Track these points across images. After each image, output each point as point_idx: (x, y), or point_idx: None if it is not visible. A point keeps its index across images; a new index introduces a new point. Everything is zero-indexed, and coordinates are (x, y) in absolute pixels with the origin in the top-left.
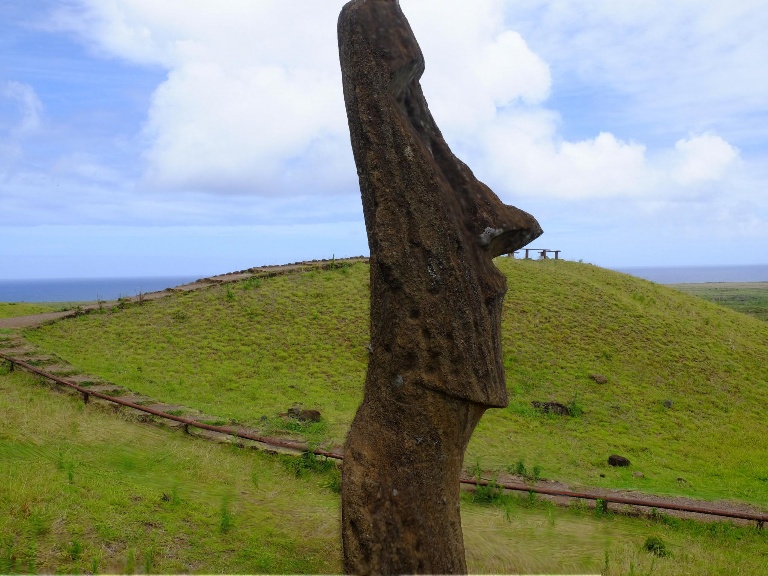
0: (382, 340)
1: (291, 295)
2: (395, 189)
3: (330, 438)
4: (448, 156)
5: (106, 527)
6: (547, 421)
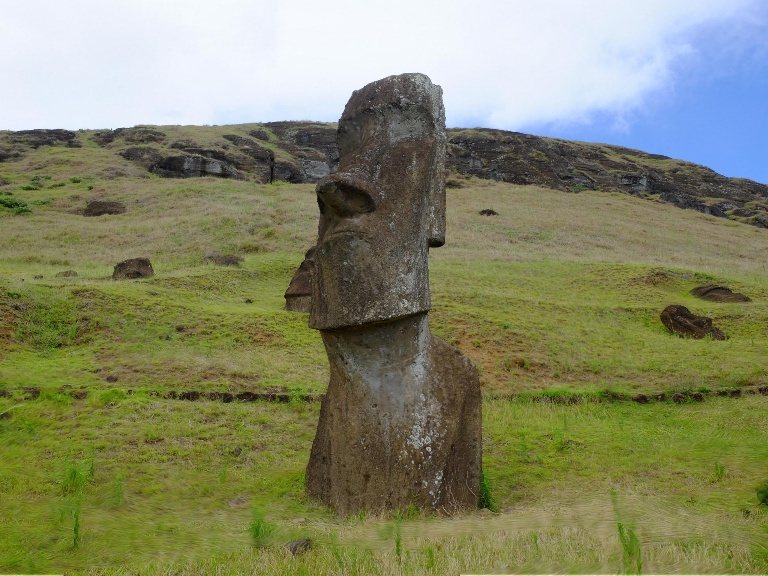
0: None
1: None
2: None
3: None
4: None
5: None
6: None
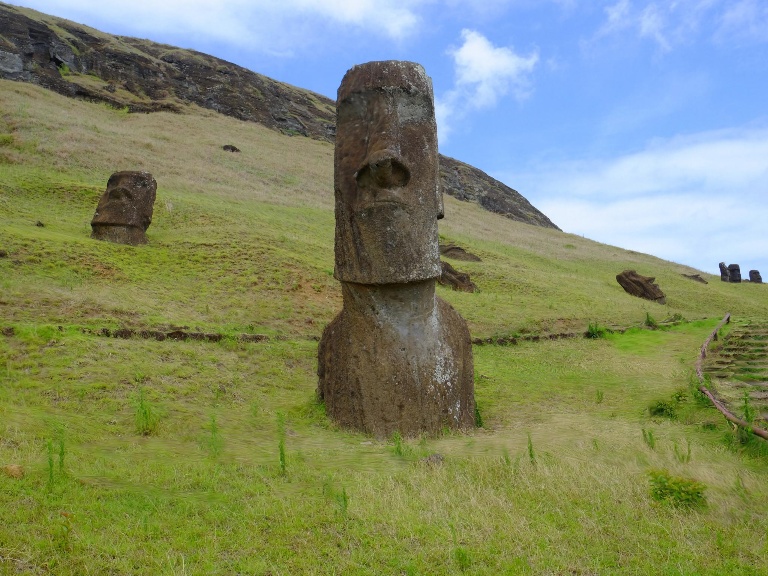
0: None
1: None
2: None
3: None
4: None
5: None
6: None
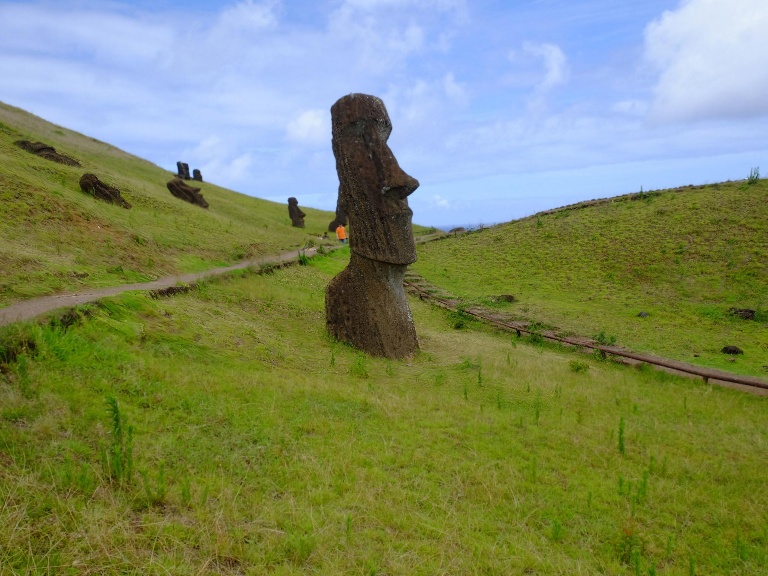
0: None
1: (588, 222)
2: (344, 176)
3: (502, 310)
4: (378, 157)
5: (295, 306)
6: (723, 322)
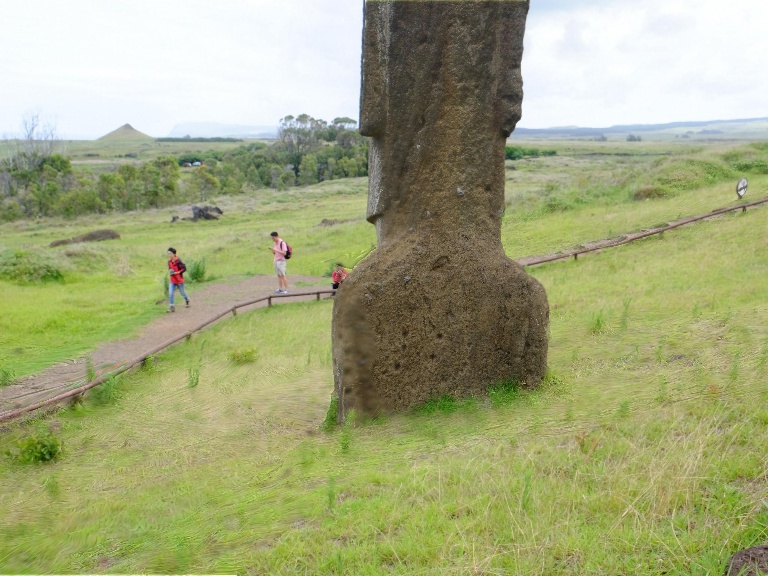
0: (483, 182)
1: None
2: None
3: None
4: None
5: None
6: None
